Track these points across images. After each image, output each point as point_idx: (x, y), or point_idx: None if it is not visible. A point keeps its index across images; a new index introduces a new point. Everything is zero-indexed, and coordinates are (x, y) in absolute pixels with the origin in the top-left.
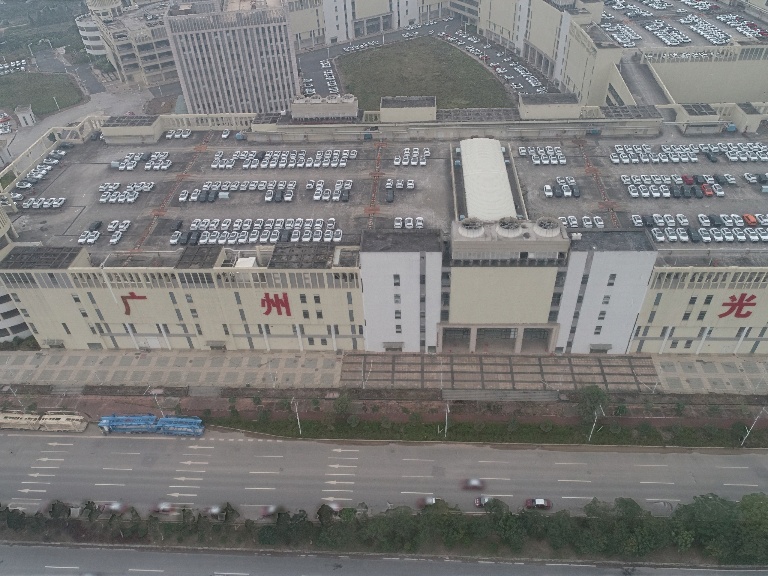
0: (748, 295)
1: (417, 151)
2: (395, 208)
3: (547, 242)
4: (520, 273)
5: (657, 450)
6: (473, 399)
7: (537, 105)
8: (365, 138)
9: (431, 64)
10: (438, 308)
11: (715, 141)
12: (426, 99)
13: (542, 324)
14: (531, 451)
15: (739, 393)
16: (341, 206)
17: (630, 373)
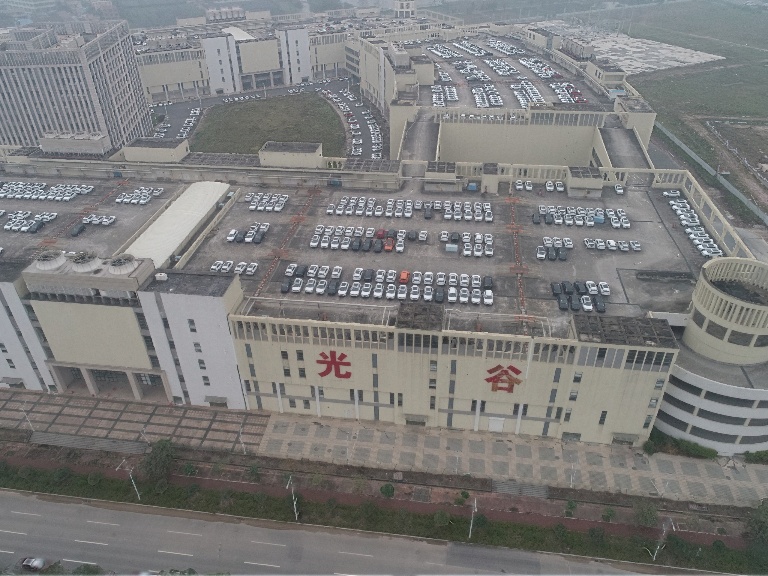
0: (338, 353)
1: (146, 190)
2: (73, 242)
3: (112, 279)
4: (99, 311)
5: (204, 517)
6: (59, 444)
7: (272, 152)
8: (115, 176)
9: (293, 117)
10: (38, 344)
11: (448, 199)
12: (178, 141)
13: (147, 369)
14: (74, 505)
15: (333, 462)
16: (25, 237)
17: (236, 431)
